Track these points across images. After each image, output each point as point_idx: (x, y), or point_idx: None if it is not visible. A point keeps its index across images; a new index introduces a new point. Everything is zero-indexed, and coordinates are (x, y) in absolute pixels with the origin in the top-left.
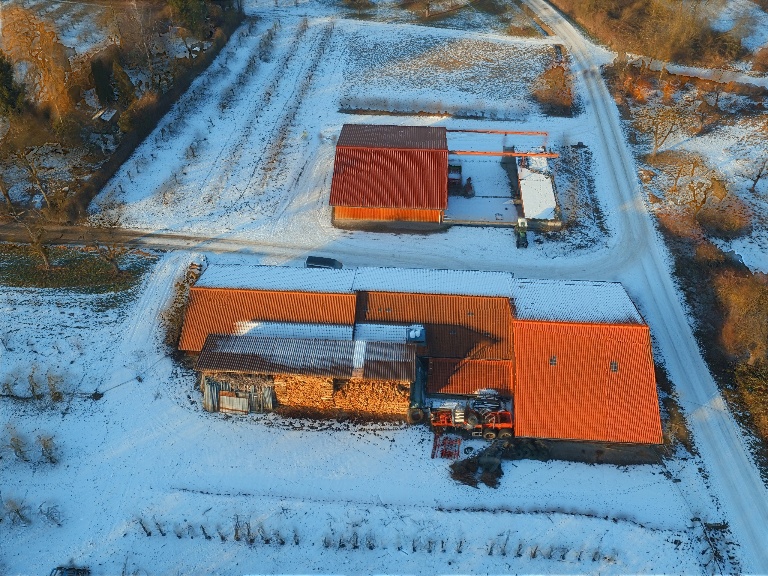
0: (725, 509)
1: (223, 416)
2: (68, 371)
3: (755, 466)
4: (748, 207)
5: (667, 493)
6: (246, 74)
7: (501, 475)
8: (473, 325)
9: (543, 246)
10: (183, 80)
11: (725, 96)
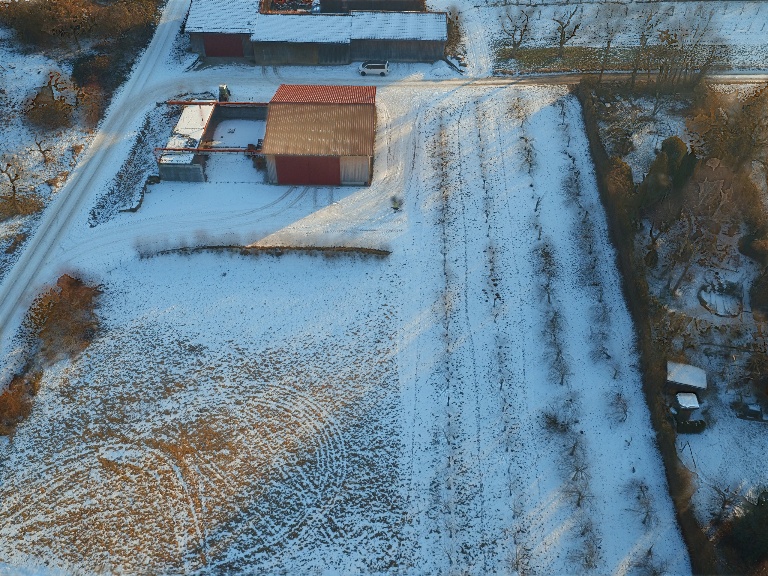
0: None
1: None
2: None
3: (169, 2)
4: (4, 133)
5: None
6: (553, 329)
7: None
8: None
9: None
10: None
11: None
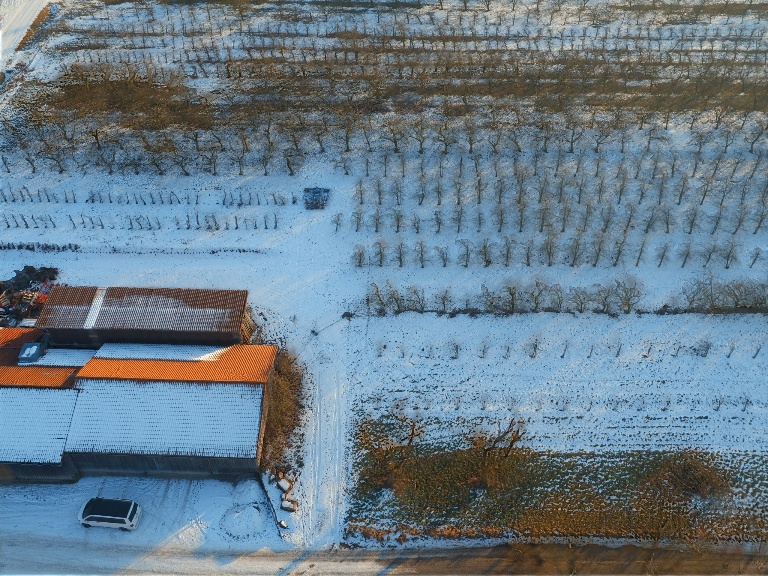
0: None
1: None
2: (384, 337)
3: None
4: None
5: None
6: None
7: None
8: None
9: None
10: None
11: None
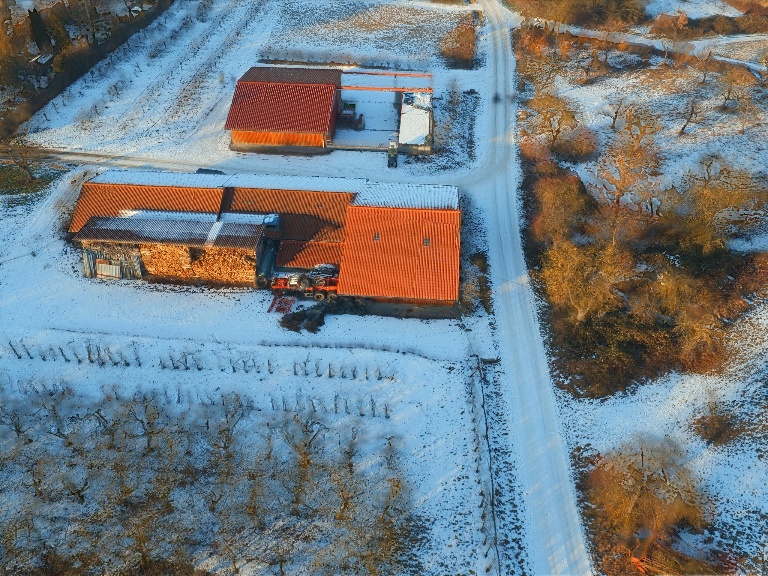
0: (502, 350)
1: (99, 281)
2: None
3: (537, 322)
4: (603, 139)
5: (457, 338)
6: (180, 30)
7: (322, 324)
8: (320, 214)
9: (411, 166)
10: (120, 34)
11: (618, 54)
